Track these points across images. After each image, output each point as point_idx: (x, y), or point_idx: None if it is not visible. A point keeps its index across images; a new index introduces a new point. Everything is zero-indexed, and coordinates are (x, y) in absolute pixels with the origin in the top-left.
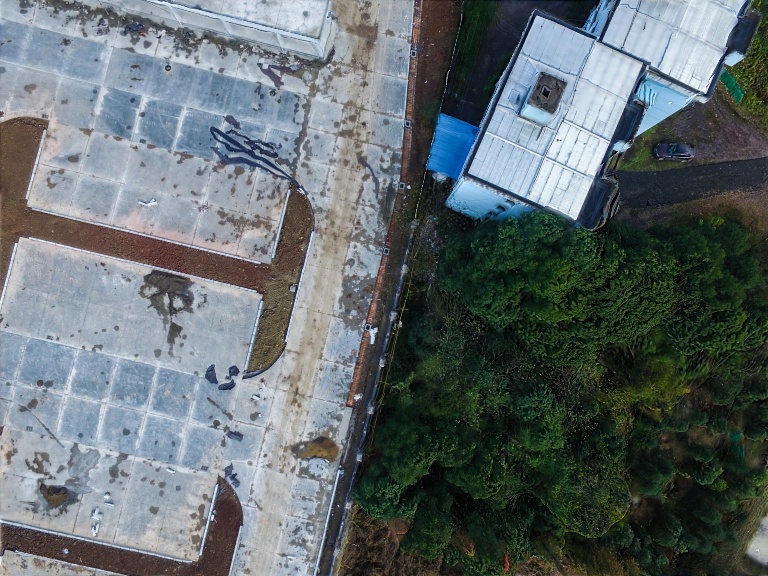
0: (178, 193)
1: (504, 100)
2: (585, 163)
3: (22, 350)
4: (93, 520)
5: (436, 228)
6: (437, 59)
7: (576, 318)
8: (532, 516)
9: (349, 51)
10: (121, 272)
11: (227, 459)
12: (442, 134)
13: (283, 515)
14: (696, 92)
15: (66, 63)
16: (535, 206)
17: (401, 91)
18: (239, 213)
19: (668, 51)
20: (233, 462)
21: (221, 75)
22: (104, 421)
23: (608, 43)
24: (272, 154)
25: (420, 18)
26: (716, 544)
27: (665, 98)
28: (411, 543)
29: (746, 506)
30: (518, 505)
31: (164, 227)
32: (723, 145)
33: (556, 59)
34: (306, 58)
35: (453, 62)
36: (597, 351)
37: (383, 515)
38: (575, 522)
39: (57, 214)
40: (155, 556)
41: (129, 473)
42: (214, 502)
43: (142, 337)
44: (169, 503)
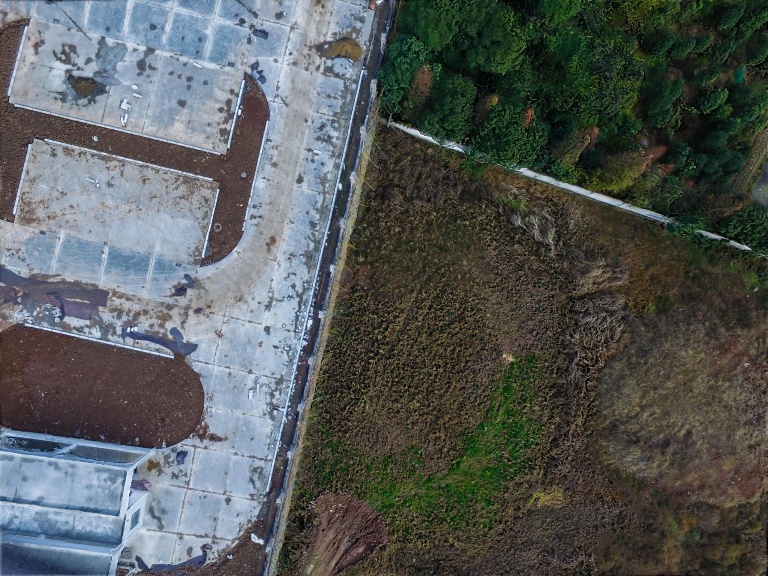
0: None
1: None
2: None
3: None
4: (121, 111)
5: None
6: None
7: None
8: (548, 128)
9: None
10: None
11: (253, 56)
12: None
13: (309, 112)
14: None
15: None
16: None
17: None
18: None
19: None
20: (259, 59)
21: None
22: (131, 16)
23: None
24: None
25: None
26: (722, 165)
27: None
28: (435, 113)
29: (749, 133)
30: (535, 113)
31: None
32: None
33: None
34: None
35: None
36: None
37: (409, 66)
38: (592, 89)
39: None
40: (184, 147)
41: (156, 67)
42: (241, 98)
43: None
44: (197, 97)
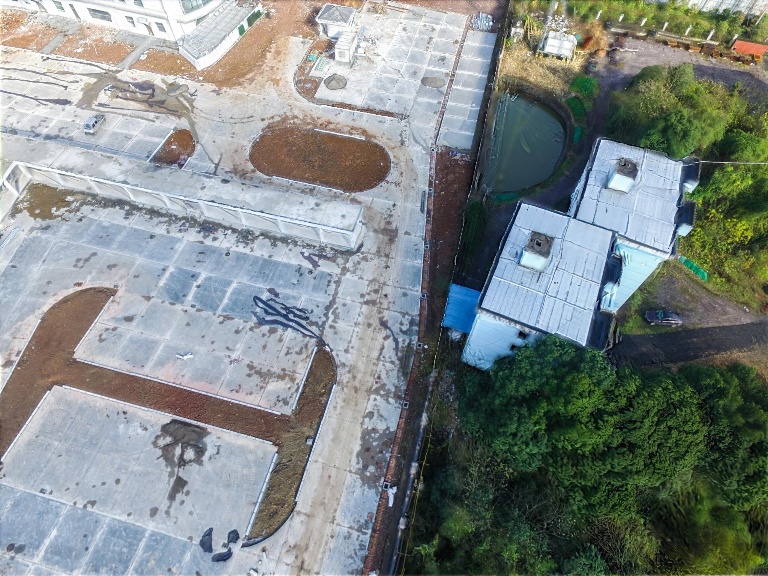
0: (214, 348)
1: (505, 255)
2: (582, 300)
3: (7, 505)
4: None
5: (454, 382)
6: (446, 250)
7: (607, 444)
8: None
9: (375, 245)
10: (140, 421)
11: None
12: (454, 299)
13: None
14: (661, 252)
15: (147, 250)
16: (545, 334)
17: (417, 272)
18: (267, 366)
19: (630, 225)
20: None
21: (270, 259)
22: None
23: (581, 220)
24: (304, 318)
25: (431, 225)
26: None
27: (638, 260)
28: None
29: None
30: None
31: (194, 378)
32: (705, 313)
33: (542, 228)
34: (340, 249)
35: (459, 249)
36: (642, 511)
37: None
38: None
39: (98, 364)
40: None
41: None
42: None
43: (142, 492)
44: None
